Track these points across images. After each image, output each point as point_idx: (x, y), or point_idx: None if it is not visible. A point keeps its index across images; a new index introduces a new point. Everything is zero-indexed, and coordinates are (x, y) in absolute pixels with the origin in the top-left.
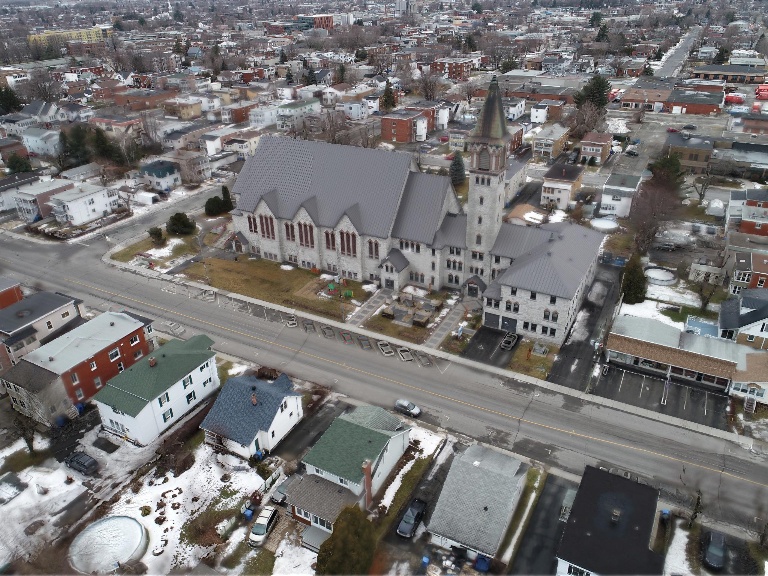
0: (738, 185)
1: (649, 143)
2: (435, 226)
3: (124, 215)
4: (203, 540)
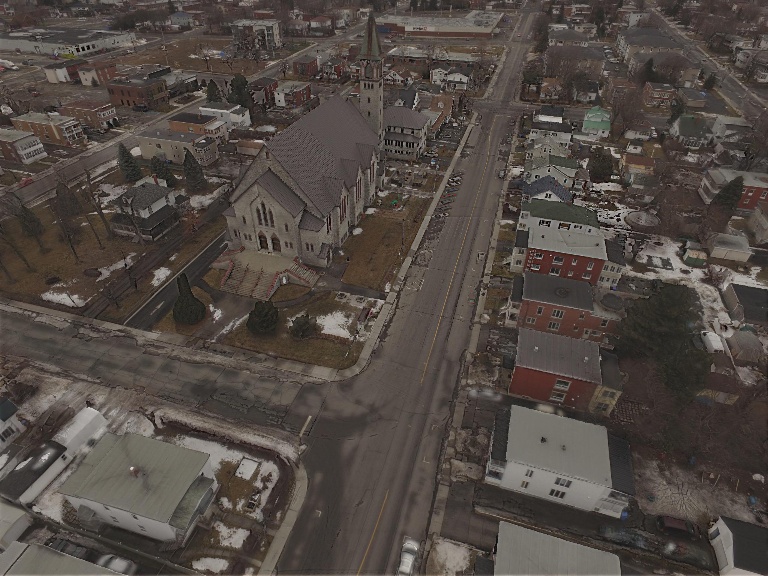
0: (197, 96)
1: None
2: None
3: (165, 436)
4: (614, 205)
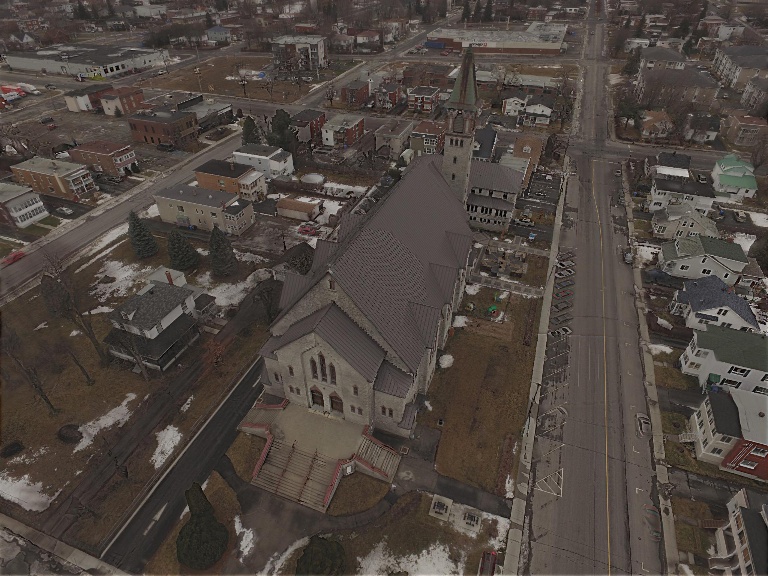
0: (231, 130)
1: (87, 141)
2: (459, 202)
3: None
4: None
